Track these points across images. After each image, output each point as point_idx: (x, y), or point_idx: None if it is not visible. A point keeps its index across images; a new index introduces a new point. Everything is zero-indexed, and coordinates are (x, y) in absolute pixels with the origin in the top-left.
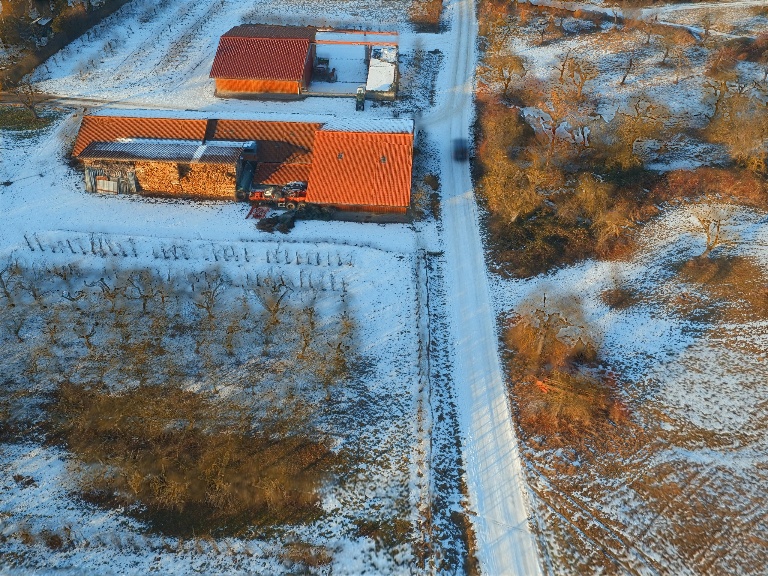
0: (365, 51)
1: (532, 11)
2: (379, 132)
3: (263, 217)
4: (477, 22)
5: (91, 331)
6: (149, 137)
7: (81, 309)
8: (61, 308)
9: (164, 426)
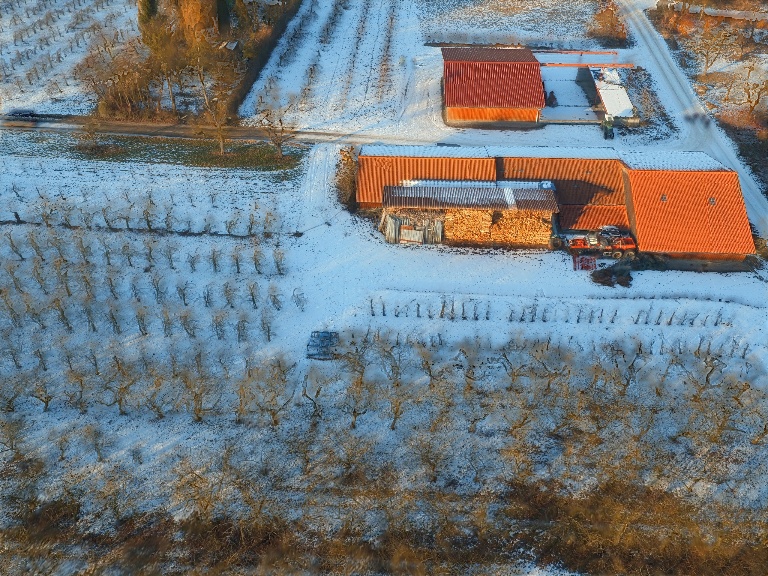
0: (578, 71)
1: (708, 22)
2: (696, 170)
3: (595, 268)
4: (660, 35)
5: (524, 419)
6: (436, 179)
7: (473, 387)
8: (451, 387)
9: (658, 535)
